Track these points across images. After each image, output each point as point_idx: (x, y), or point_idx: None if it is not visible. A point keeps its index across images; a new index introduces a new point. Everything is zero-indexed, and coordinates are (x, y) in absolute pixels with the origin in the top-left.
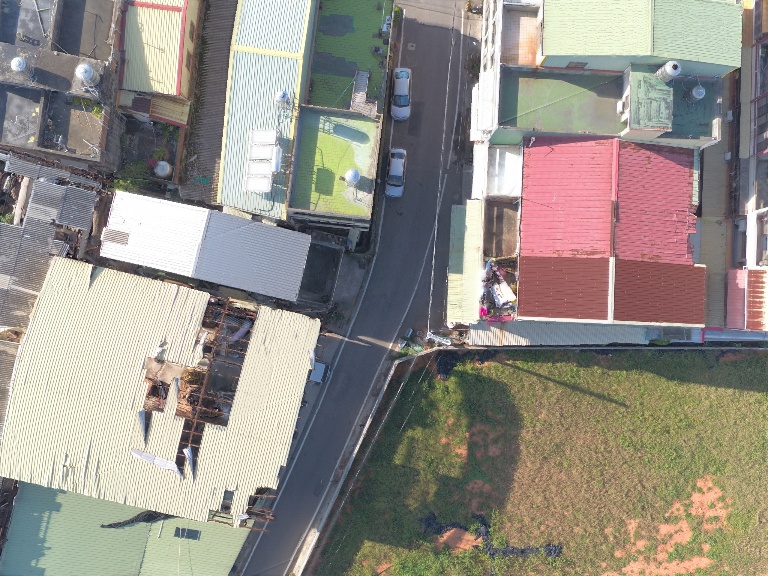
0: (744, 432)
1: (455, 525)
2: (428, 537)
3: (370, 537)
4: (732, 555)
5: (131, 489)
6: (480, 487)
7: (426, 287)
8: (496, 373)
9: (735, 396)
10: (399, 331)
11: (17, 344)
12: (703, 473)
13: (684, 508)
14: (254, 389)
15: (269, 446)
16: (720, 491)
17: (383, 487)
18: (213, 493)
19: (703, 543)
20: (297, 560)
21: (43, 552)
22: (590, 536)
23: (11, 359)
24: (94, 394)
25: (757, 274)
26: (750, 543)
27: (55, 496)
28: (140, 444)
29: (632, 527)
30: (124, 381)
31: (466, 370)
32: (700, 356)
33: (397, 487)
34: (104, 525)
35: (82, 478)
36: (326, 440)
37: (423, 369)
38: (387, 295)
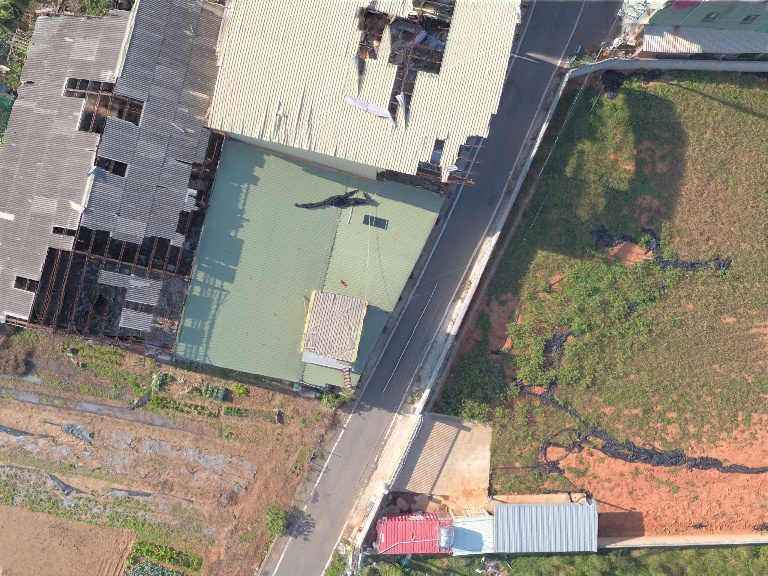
0: None
1: (626, 238)
2: (600, 248)
3: (543, 247)
4: None
5: (342, 139)
6: (649, 203)
7: (591, 8)
8: (662, 91)
9: None
10: (566, 50)
11: (223, 7)
12: None
13: None
14: (464, 39)
15: (480, 94)
16: None
17: (555, 199)
18: (424, 142)
19: None
20: (473, 267)
21: (242, 224)
22: (757, 252)
23: (217, 20)
24: (308, 41)
25: None
26: None
27: (253, 169)
28: (353, 91)
29: None
30: (337, 29)
31: (633, 88)
32: None
33: (569, 199)
34: (298, 204)
35: (294, 128)
36: (498, 153)
37: (590, 87)
38: (554, 15)
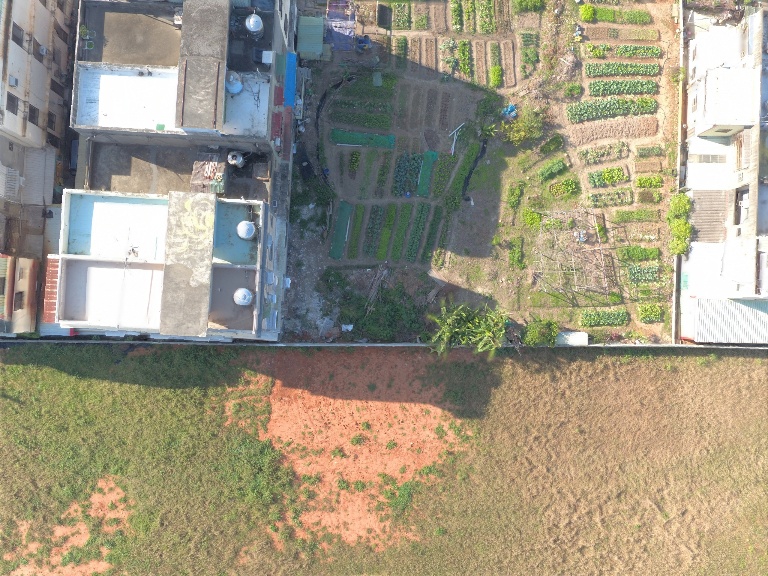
0: (149, 430)
1: None
2: None
3: None
4: (130, 559)
5: None
6: None
7: None
8: None
9: (141, 392)
10: None
11: None
12: (103, 473)
13: (82, 509)
14: None
15: None
16: (122, 492)
17: None
18: None
19: (100, 546)
20: None
21: None
22: None
23: None
24: None
25: (55, 263)
26: (150, 546)
27: None
28: None
29: (24, 529)
30: None
31: None
32: (105, 350)
33: None
34: None
35: None
36: None
37: None
38: None
